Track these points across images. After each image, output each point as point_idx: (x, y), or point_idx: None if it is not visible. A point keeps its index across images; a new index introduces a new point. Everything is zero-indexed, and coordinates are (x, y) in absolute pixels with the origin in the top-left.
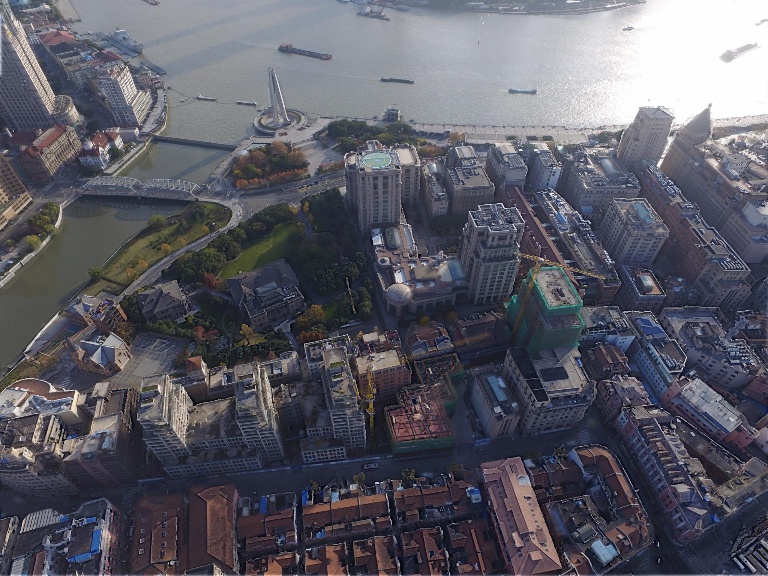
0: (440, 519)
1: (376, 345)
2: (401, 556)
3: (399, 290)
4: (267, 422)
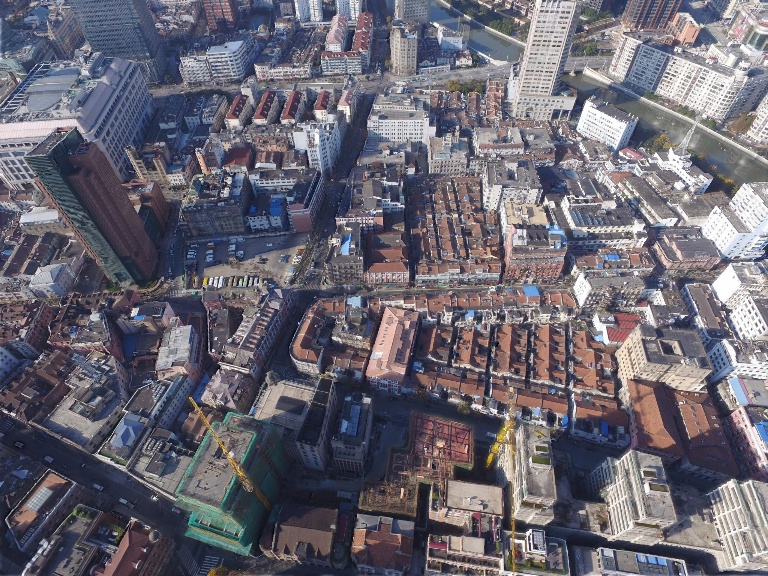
0: None
1: None
2: (488, 361)
3: None
4: None
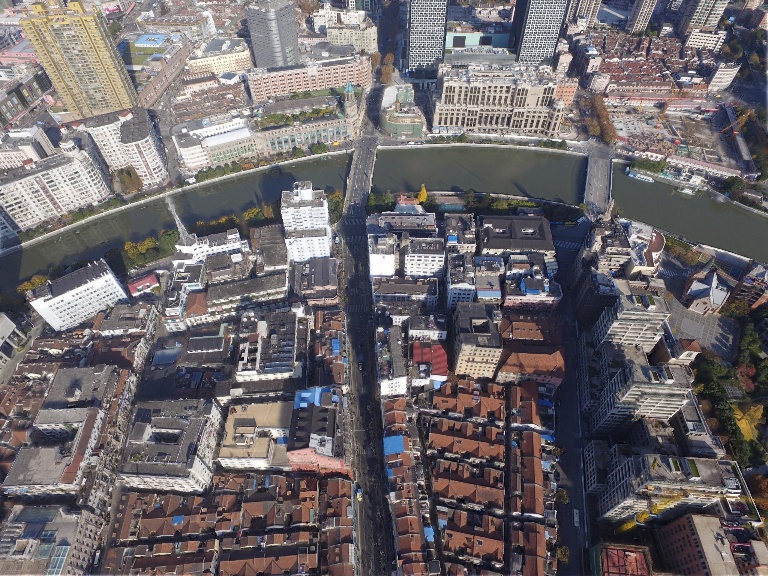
0: (511, 571)
1: (750, 561)
2: None
3: None
4: (622, 400)
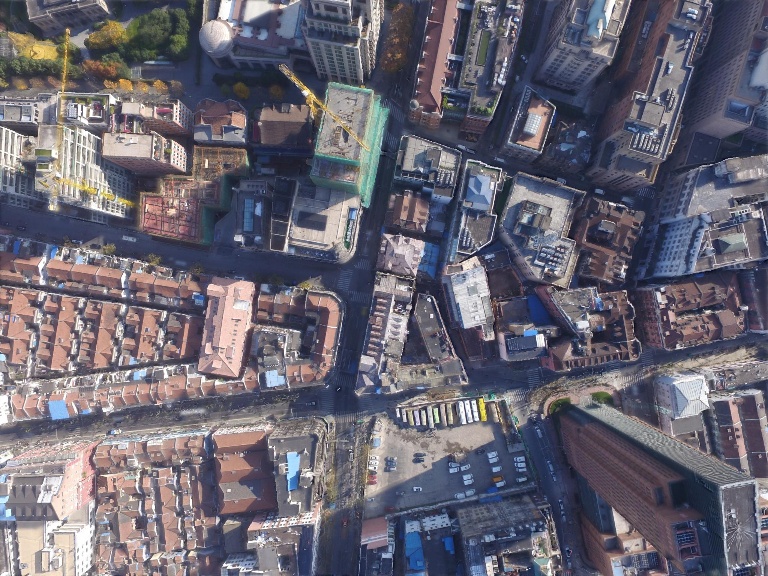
0: (169, 305)
1: (141, 118)
2: None
3: (211, 35)
4: None
